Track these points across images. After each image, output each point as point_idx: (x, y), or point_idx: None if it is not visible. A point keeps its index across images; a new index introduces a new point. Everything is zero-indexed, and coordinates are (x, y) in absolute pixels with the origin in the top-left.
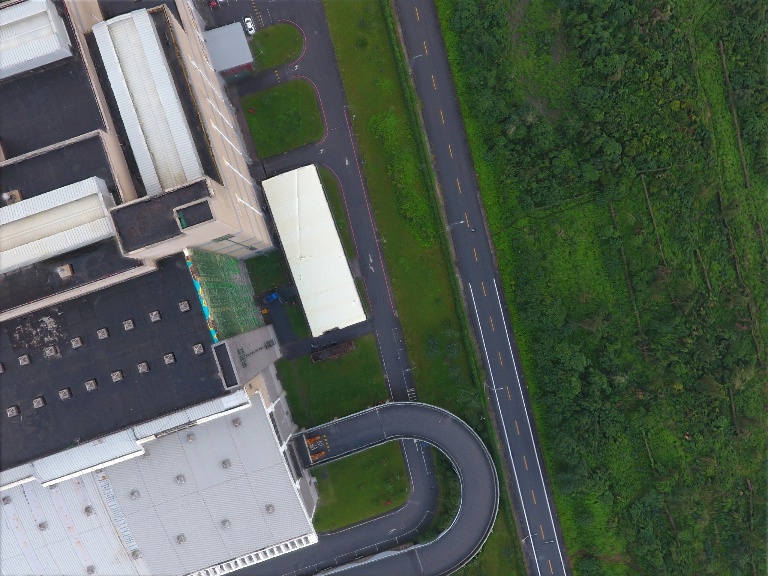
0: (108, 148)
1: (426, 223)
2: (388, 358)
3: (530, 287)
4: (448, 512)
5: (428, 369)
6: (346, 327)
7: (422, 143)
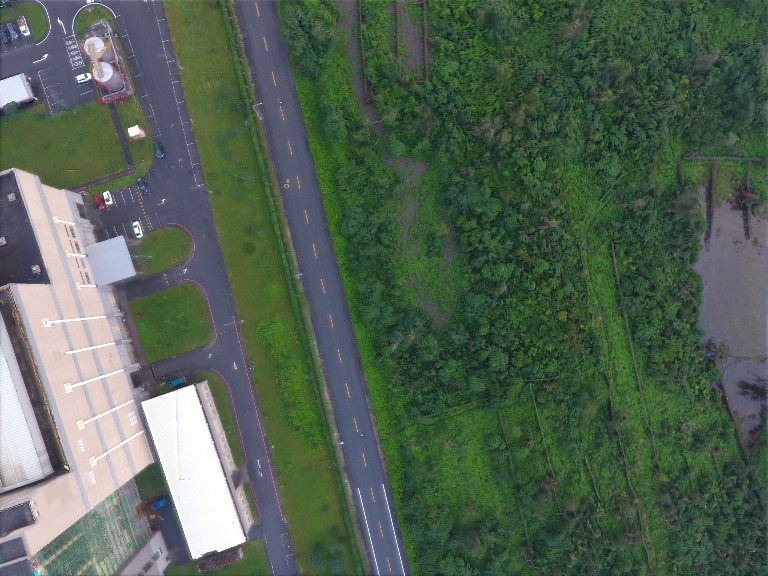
0: None
1: (313, 431)
2: (277, 564)
3: (415, 501)
4: None
5: (316, 575)
6: None
7: (310, 349)
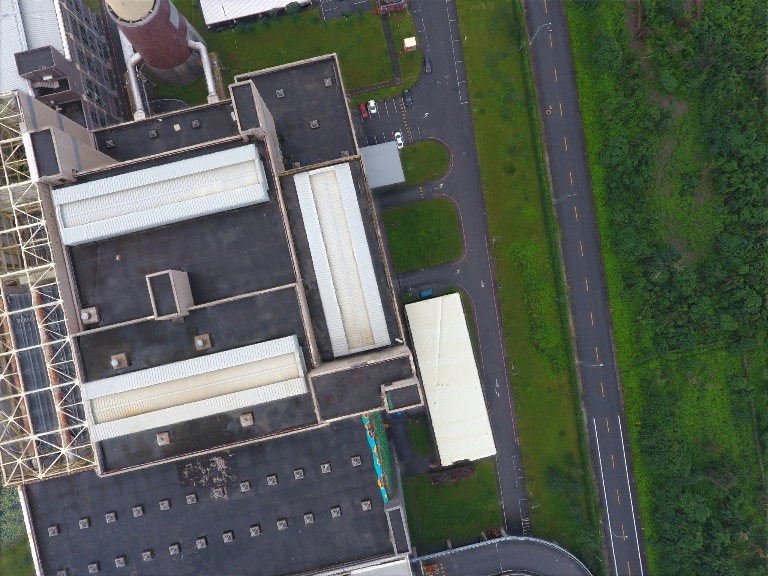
0: (302, 302)
1: (557, 355)
2: (505, 485)
3: (659, 432)
4: None
5: (545, 501)
6: None
7: (560, 274)
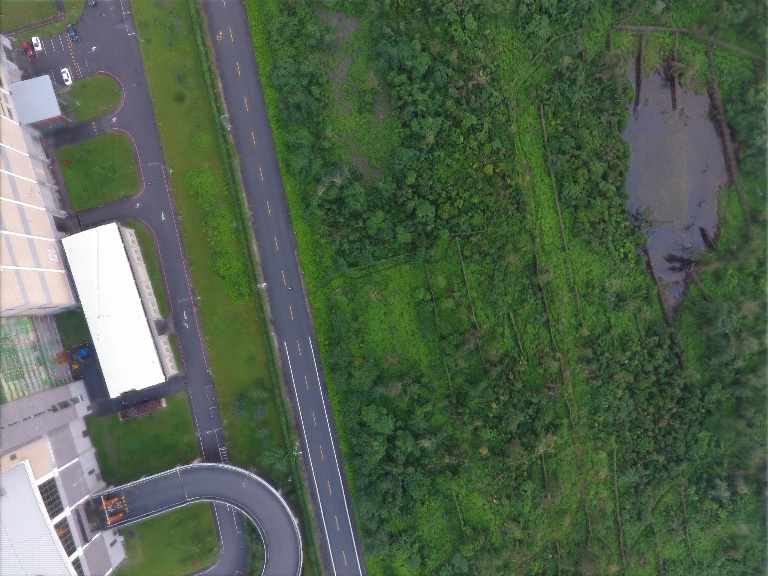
0: None
1: (240, 281)
2: (200, 416)
3: (339, 349)
4: (253, 574)
5: (240, 428)
6: (158, 384)
7: (239, 200)
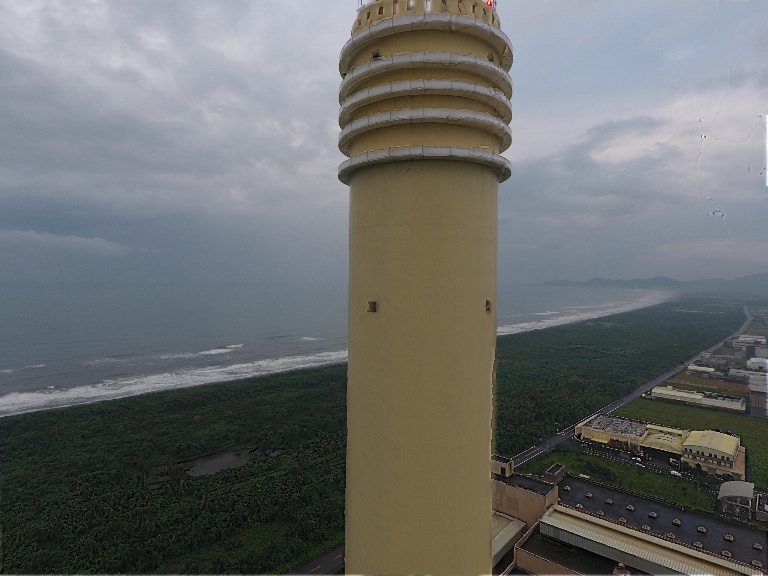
0: None
1: None
2: None
3: None
4: None
5: None
6: None
7: None
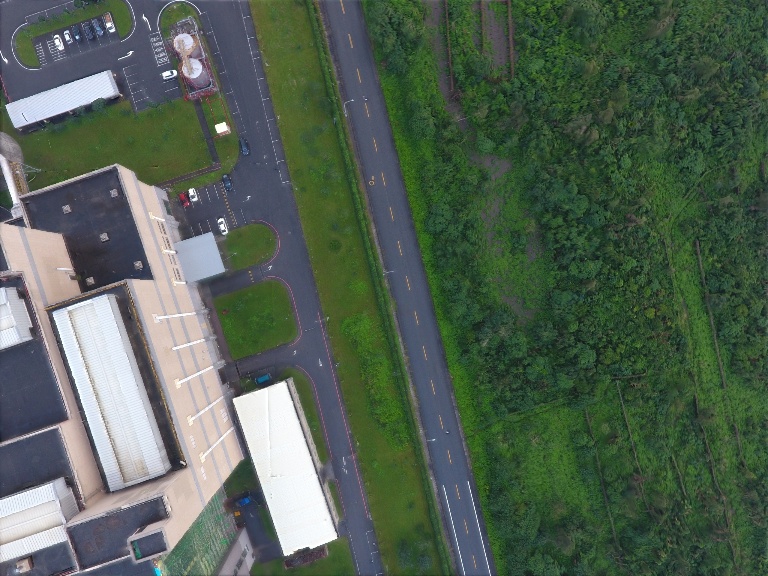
0: (67, 443)
1: (400, 428)
2: (361, 561)
3: (503, 498)
4: None
5: (402, 573)
6: None
7: (396, 346)
